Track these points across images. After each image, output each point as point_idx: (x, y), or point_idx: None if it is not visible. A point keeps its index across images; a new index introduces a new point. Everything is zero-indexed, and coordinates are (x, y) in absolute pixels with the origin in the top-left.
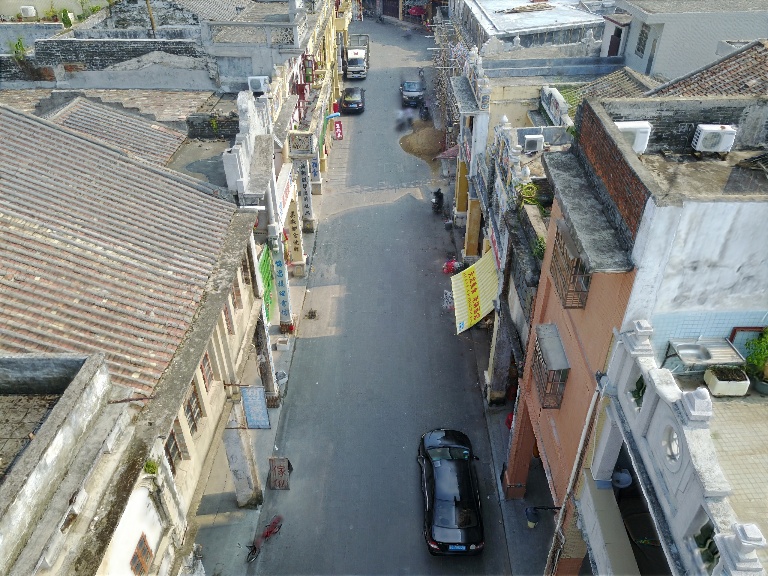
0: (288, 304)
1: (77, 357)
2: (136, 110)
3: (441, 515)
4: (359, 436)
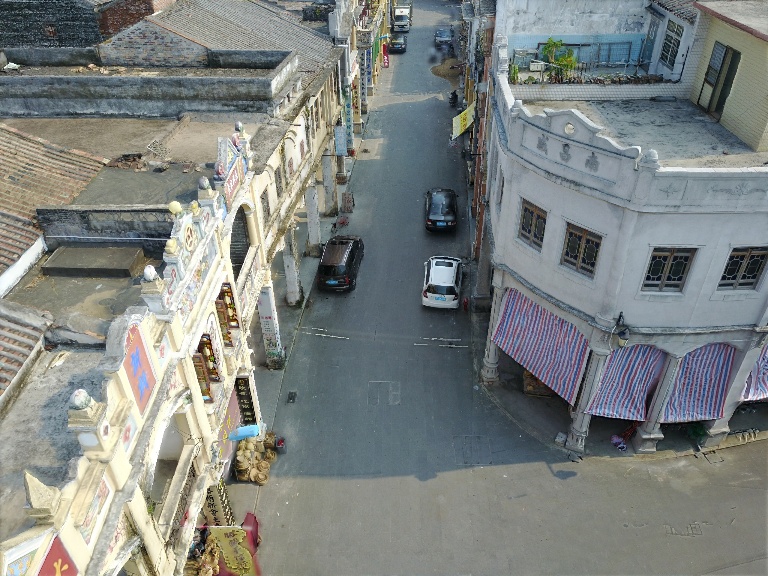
0: (352, 135)
1: (289, 50)
2: (275, 3)
3: (434, 211)
4: (392, 196)
